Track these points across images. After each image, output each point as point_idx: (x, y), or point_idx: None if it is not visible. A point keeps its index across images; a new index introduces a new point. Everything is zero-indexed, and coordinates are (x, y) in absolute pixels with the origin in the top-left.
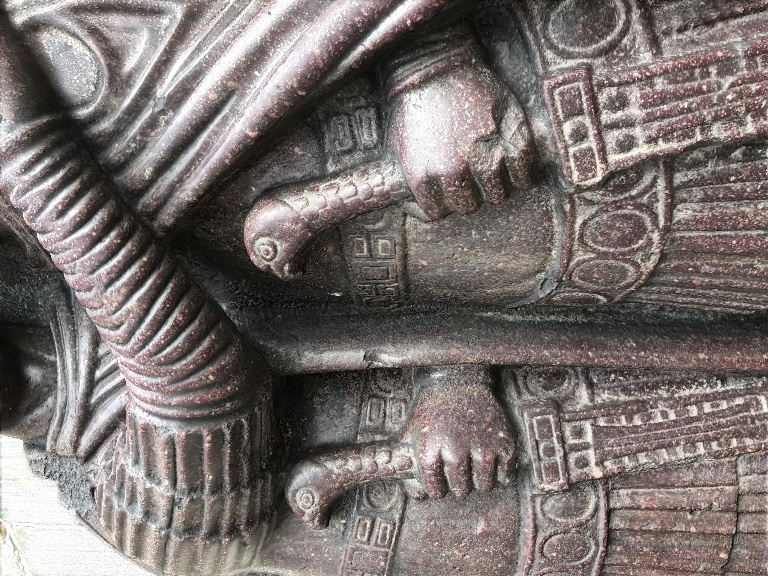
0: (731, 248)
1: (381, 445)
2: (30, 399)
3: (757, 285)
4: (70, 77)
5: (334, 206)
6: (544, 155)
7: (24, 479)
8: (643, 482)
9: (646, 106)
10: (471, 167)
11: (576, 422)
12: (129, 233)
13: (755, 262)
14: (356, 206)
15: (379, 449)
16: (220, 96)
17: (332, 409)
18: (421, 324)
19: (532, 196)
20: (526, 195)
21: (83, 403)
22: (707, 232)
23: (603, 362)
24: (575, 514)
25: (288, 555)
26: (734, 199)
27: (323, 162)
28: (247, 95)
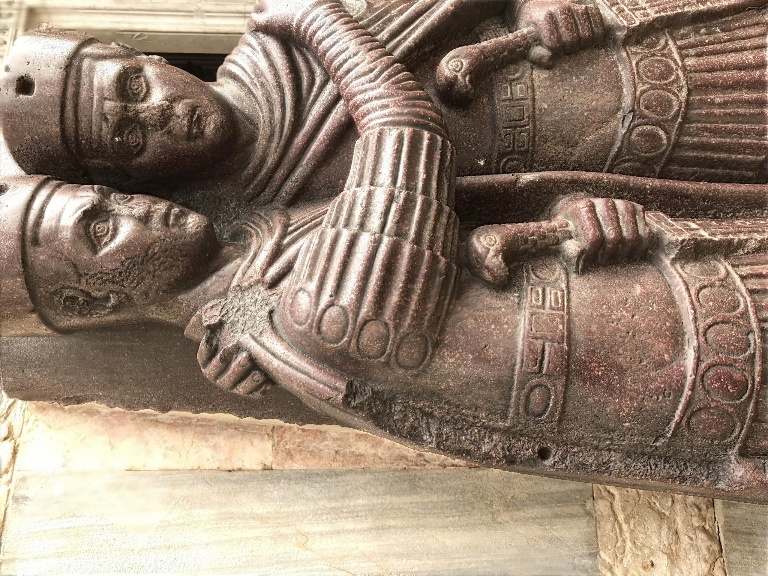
0: (725, 80)
1: None
2: (221, 259)
3: (753, 111)
4: None
5: (496, 42)
6: (605, 21)
7: None
8: (754, 260)
9: (648, 2)
10: (572, 7)
11: (681, 222)
12: None
13: (744, 94)
14: (509, 42)
15: None
16: (431, 1)
17: None
18: None
19: (603, 53)
20: (600, 53)
21: (277, 241)
22: (708, 74)
23: (681, 185)
24: (712, 274)
25: (469, 328)
26: (713, 52)
27: None
28: (446, 0)
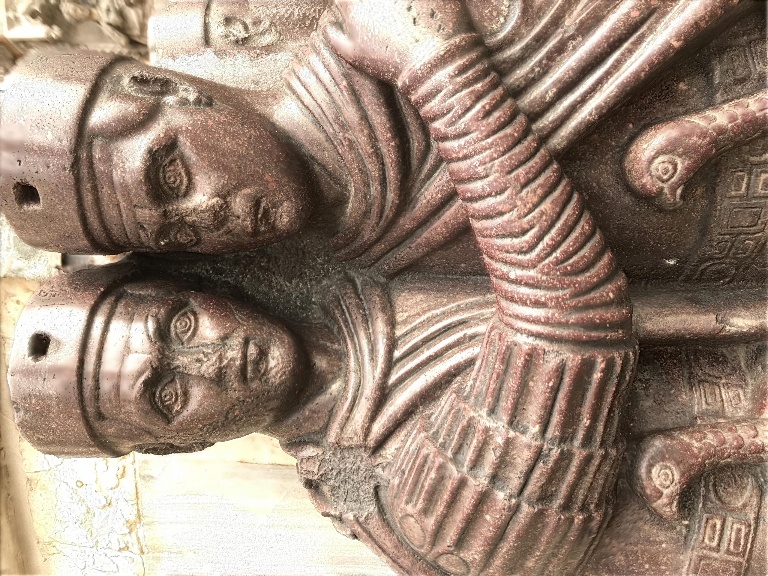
0: None
1: (738, 421)
2: (313, 386)
3: None
4: (481, 11)
5: (746, 119)
6: None
7: (189, 552)
8: None
9: None
10: None
11: None
12: (540, 142)
13: None
14: None
15: (738, 424)
16: (642, 13)
17: (658, 394)
18: (766, 293)
19: None
20: None
21: (380, 384)
22: None
23: None
24: None
25: (616, 566)
26: None
27: (710, 94)
28: (669, 12)
